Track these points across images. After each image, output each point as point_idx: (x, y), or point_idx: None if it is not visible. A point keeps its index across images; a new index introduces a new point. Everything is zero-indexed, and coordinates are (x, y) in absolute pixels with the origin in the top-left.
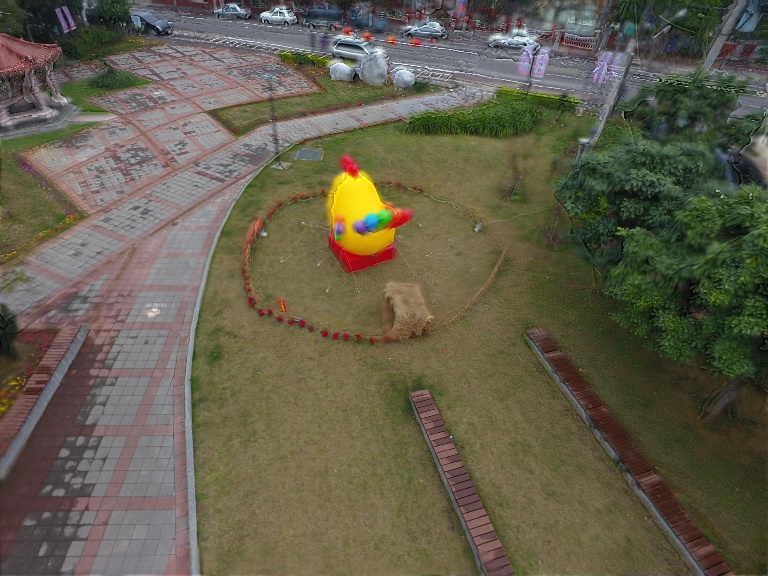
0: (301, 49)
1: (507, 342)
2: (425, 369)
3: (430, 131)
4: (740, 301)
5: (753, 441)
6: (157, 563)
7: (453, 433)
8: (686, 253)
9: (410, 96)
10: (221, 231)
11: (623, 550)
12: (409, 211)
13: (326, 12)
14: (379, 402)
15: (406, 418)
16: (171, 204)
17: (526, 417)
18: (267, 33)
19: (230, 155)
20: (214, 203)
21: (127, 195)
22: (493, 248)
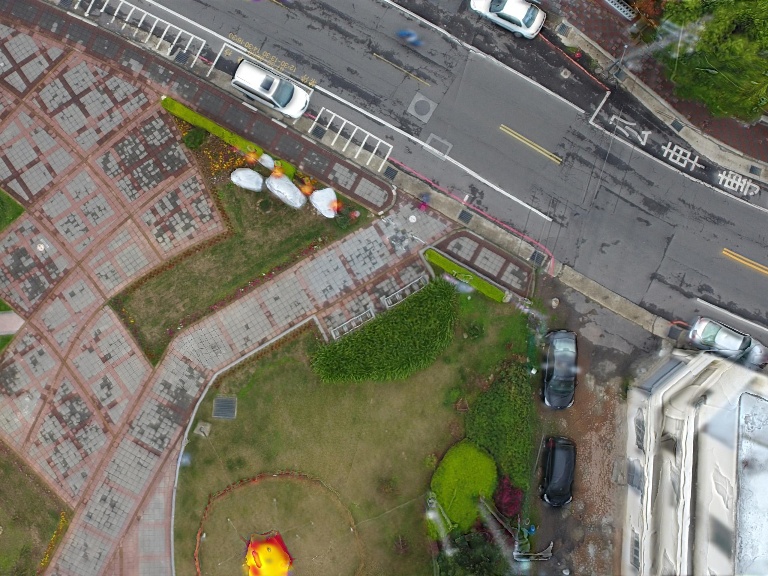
0: (183, 17)
1: None
2: None
3: (334, 383)
4: None
5: None
6: None
7: None
8: None
9: (329, 239)
10: (174, 530)
11: None
12: (306, 504)
13: None
14: None
15: None
16: (128, 492)
17: None
18: None
19: (155, 407)
20: (160, 488)
21: (92, 480)
22: (359, 552)
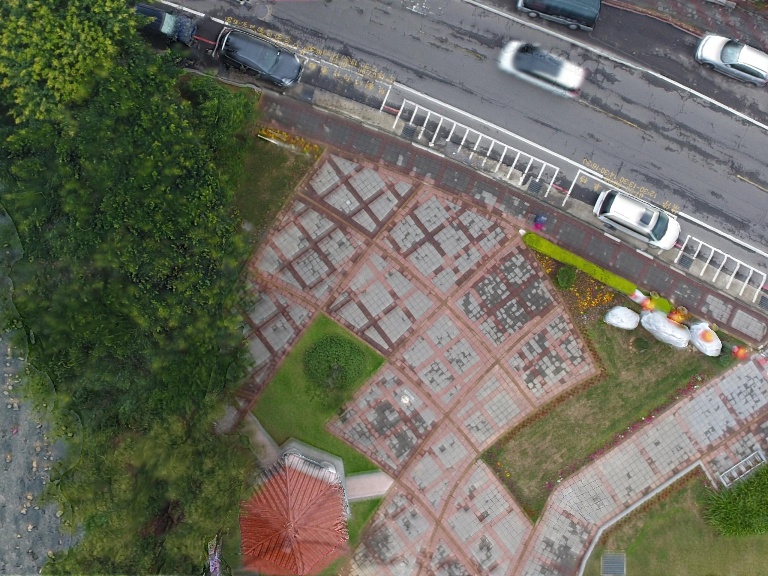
0: (533, 143)
1: None
2: None
3: (736, 537)
4: None
5: None
6: None
7: None
8: None
9: (708, 377)
10: None
11: None
12: None
13: (570, 6)
14: None
15: None
16: None
17: None
18: (458, 43)
19: (539, 567)
20: None
21: None
22: None
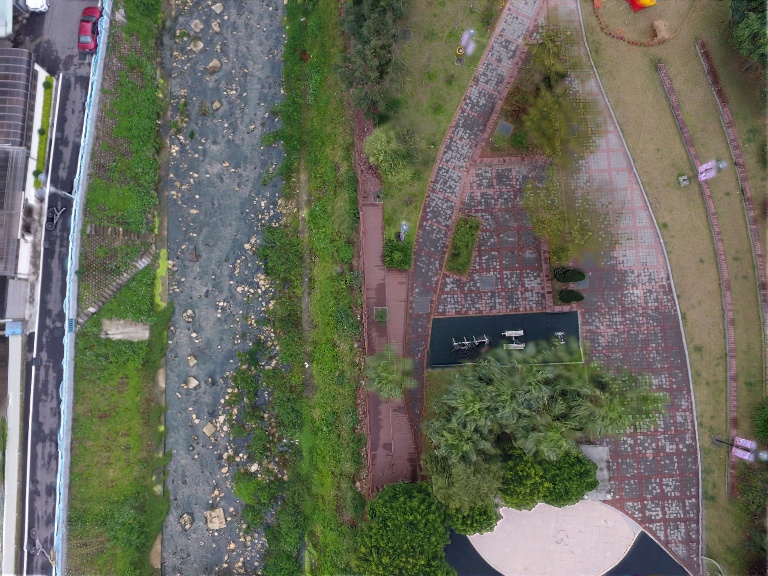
0: None
1: (689, 46)
2: (662, 56)
3: None
4: (763, 46)
5: (751, 79)
6: (600, 107)
7: (669, 77)
8: (760, 25)
9: None
10: None
11: (706, 105)
12: None
13: None
14: (648, 68)
15: (655, 73)
16: None
17: (690, 72)
18: None
19: None
20: None
21: None
22: None
